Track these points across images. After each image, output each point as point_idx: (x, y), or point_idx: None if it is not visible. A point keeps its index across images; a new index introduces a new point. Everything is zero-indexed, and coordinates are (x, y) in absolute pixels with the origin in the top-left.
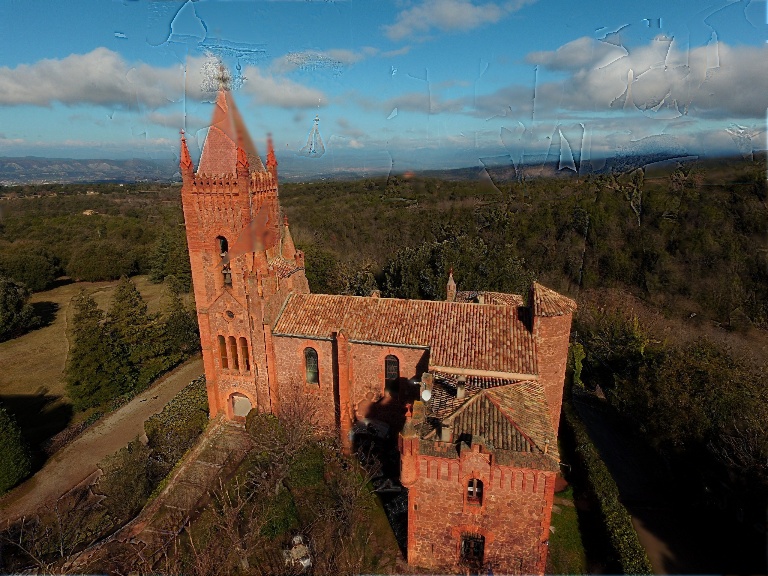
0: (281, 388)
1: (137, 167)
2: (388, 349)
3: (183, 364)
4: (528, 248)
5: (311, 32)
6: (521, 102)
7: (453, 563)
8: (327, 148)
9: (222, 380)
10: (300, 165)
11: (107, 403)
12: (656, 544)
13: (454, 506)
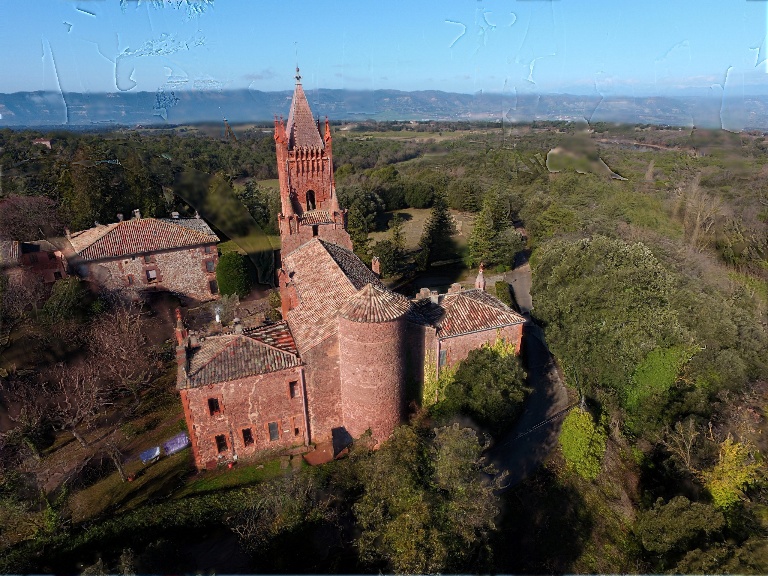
0: None
1: (470, 120)
2: None
3: (381, 280)
4: None
5: (199, 66)
6: None
7: None
8: (628, 106)
9: None
10: (595, 125)
11: None
12: None
13: None
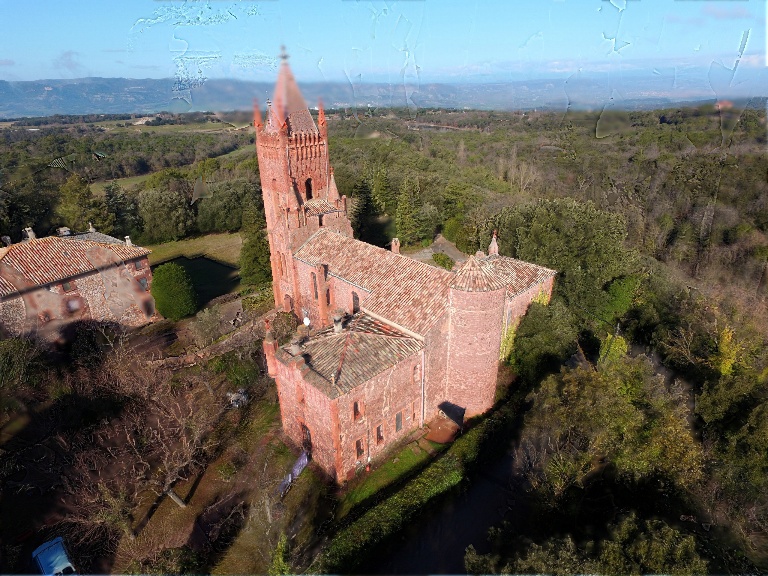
0: (302, 298)
1: None
2: (352, 287)
3: None
4: (724, 221)
5: (246, 39)
6: (725, 30)
7: (301, 442)
8: (507, 88)
9: (281, 283)
10: (479, 105)
11: (258, 284)
12: (470, 512)
13: (295, 401)
